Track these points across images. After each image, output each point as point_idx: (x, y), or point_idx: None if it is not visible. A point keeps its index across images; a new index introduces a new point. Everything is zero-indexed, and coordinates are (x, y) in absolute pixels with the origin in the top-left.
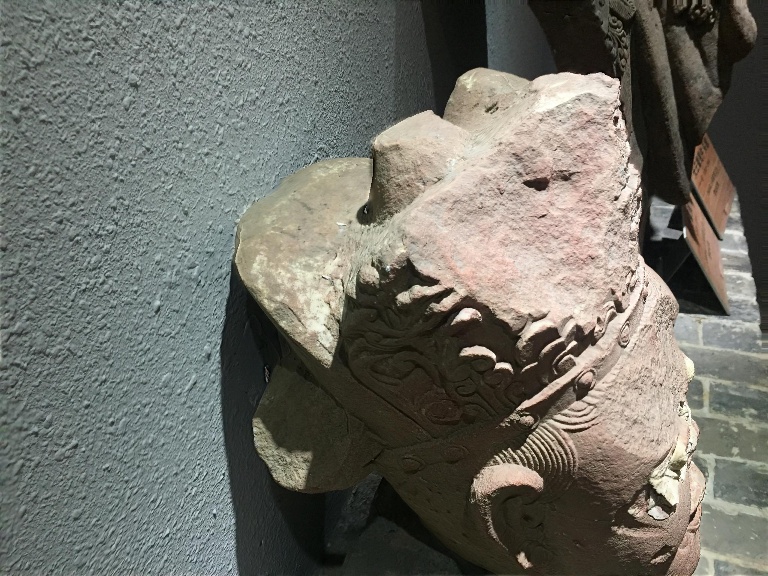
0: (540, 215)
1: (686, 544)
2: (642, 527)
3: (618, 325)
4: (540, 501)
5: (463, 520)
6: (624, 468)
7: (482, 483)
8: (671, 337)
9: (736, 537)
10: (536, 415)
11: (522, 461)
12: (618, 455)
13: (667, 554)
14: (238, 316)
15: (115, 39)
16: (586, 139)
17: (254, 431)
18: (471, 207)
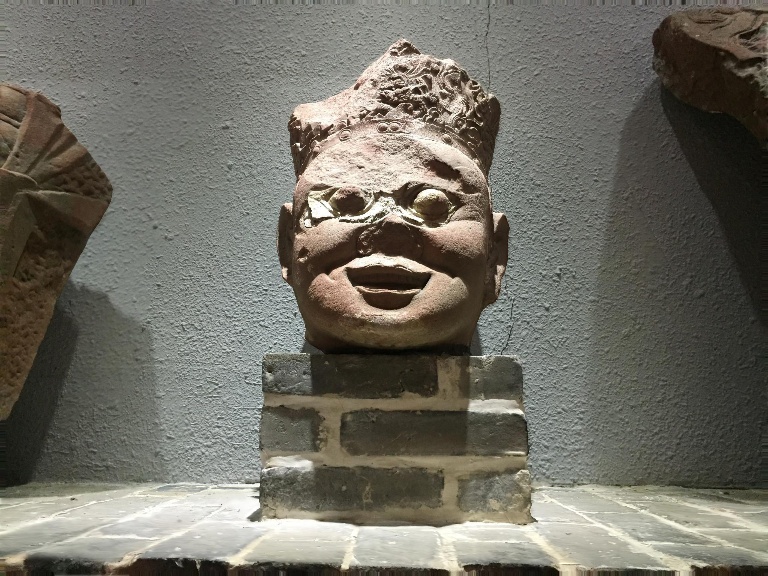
0: None
1: (335, 279)
2: None
3: None
4: None
5: None
6: None
7: None
8: (413, 166)
9: (590, 548)
10: None
11: None
12: None
13: (306, 257)
14: None
15: None
16: None
17: None
18: None
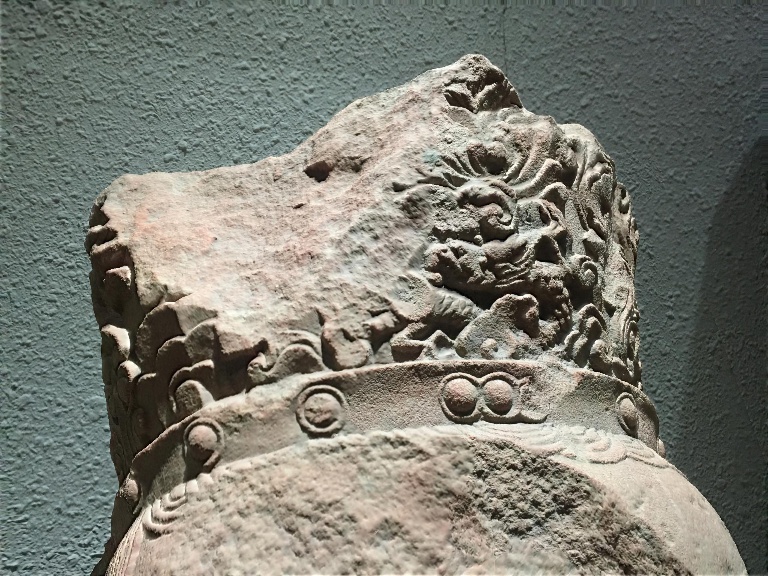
0: (296, 204)
1: None
2: None
3: (306, 379)
4: None
5: None
6: None
7: None
8: None
9: None
10: (140, 484)
11: None
12: None
13: None
14: None
15: (177, 113)
16: (399, 120)
17: None
18: (229, 185)
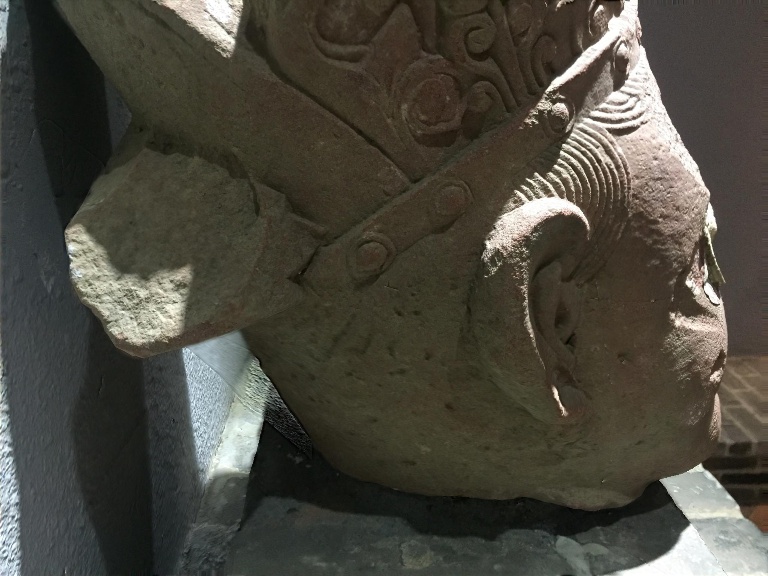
0: None
1: None
2: (699, 314)
3: (632, 6)
4: (577, 279)
5: (455, 360)
6: (684, 195)
7: (508, 230)
8: None
9: None
10: (571, 104)
11: (558, 190)
12: (677, 171)
13: (721, 370)
14: (21, 103)
15: None
16: None
17: (70, 249)
18: None
